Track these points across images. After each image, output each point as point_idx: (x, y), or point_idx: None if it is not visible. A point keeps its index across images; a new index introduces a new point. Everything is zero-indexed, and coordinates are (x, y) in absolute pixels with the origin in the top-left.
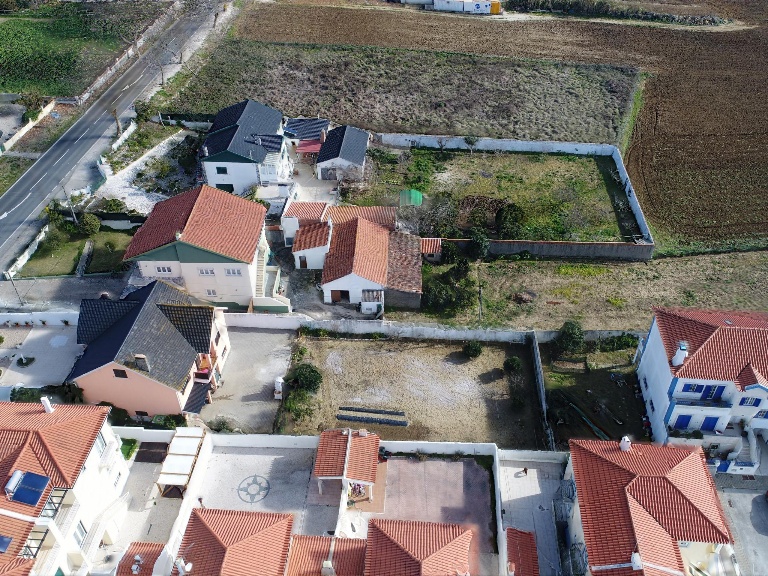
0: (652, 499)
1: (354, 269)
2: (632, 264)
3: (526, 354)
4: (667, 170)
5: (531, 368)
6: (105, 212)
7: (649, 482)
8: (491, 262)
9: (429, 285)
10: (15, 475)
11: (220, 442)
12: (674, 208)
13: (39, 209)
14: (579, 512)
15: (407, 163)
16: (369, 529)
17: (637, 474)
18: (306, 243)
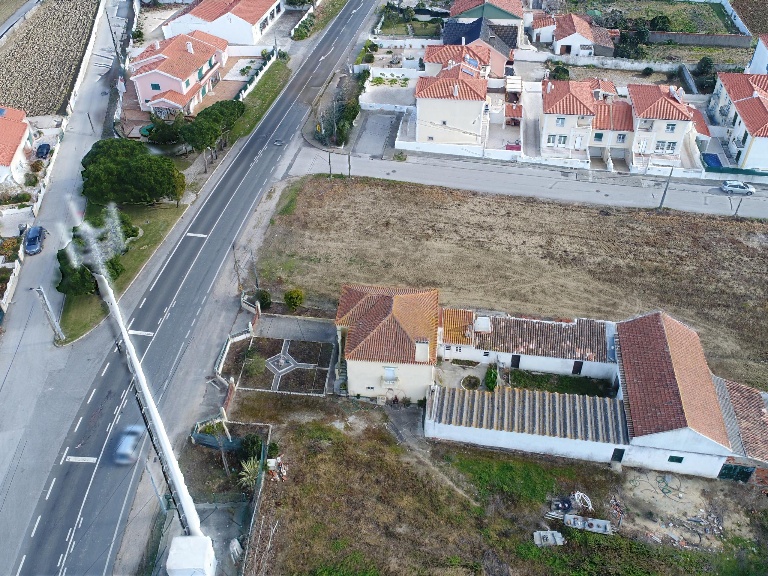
0: (762, 83)
1: (577, 31)
2: (738, 49)
3: (679, 76)
4: (759, 12)
5: (683, 80)
6: (417, 9)
7: (760, 77)
8: (650, 45)
9: (619, 45)
10: (468, 55)
11: (527, 87)
12: (764, 28)
13: (373, 9)
14: (724, 96)
15: (584, 3)
16: (628, 86)
17: (754, 74)
18: (541, 25)
